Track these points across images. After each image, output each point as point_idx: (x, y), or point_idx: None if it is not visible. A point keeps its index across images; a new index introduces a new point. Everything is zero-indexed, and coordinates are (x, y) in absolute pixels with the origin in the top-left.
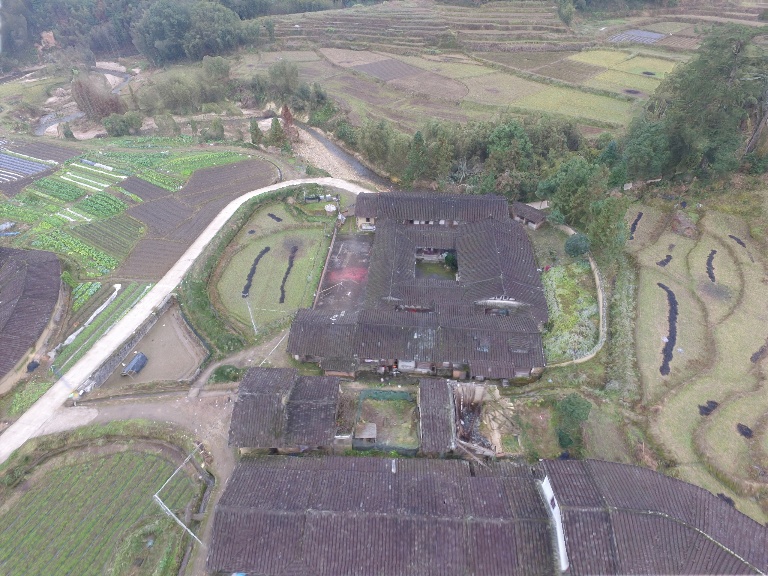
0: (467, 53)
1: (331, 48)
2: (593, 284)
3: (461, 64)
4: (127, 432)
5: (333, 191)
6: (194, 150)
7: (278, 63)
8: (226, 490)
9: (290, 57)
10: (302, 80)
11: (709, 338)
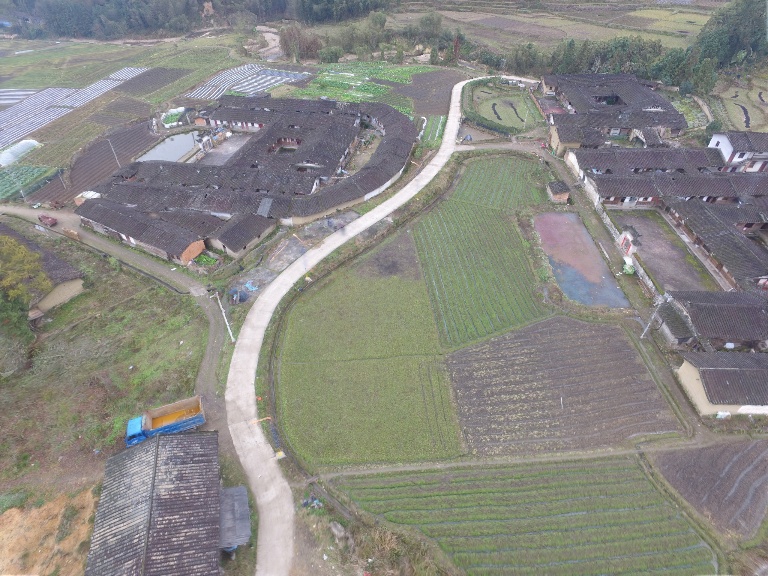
0: (551, 12)
1: (444, 11)
2: (698, 106)
3: (550, 19)
4: (495, 152)
5: None
6: (397, 66)
7: (428, 15)
8: None
9: (416, 16)
10: None
11: (767, 117)
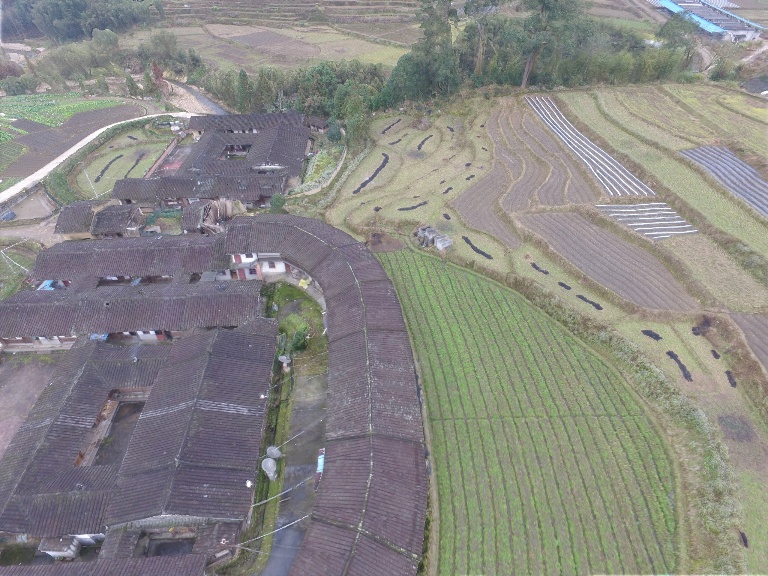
0: (331, 25)
1: (216, 24)
2: None
3: (323, 33)
4: None
5: (183, 120)
6: (78, 100)
7: (158, 33)
8: (47, 249)
9: (178, 32)
10: (183, 48)
11: None
